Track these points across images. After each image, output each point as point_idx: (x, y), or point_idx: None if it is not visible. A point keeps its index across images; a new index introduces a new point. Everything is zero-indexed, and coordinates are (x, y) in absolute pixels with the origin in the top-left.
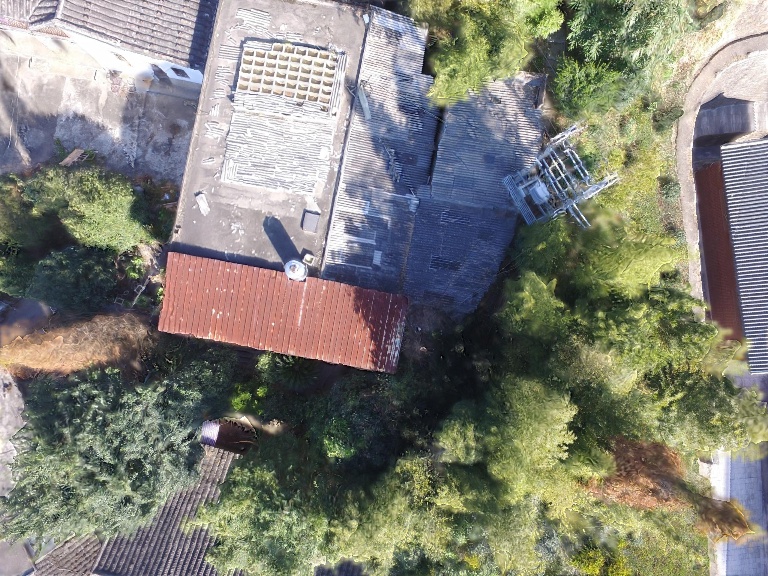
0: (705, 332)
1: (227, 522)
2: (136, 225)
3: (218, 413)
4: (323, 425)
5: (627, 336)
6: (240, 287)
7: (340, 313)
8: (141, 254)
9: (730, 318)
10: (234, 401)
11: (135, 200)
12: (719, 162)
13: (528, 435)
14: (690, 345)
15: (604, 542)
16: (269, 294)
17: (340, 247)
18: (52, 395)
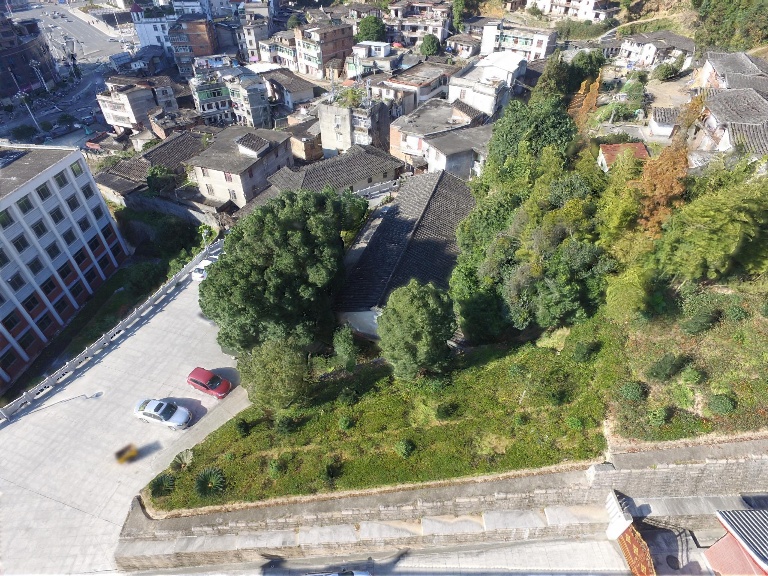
0: None
1: None
2: None
3: None
4: None
5: None
6: None
7: None
8: None
9: None
10: None
11: None
12: None
13: None
14: None
15: None
16: None
17: None
18: None
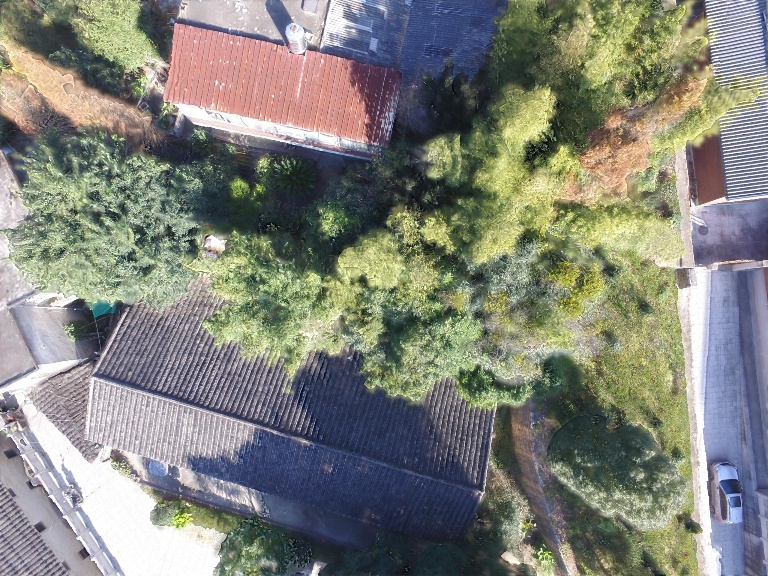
0: (674, 11)
1: (225, 281)
2: (143, 37)
3: (218, 213)
4: (318, 217)
5: (603, 29)
6: (242, 59)
7: (337, 86)
8: (146, 77)
9: (711, 161)
10: (234, 185)
11: (142, 13)
12: (703, 12)
13: (510, 126)
14: (661, 34)
15: (581, 261)
16: (270, 66)
17: (338, 31)
18: (61, 140)
